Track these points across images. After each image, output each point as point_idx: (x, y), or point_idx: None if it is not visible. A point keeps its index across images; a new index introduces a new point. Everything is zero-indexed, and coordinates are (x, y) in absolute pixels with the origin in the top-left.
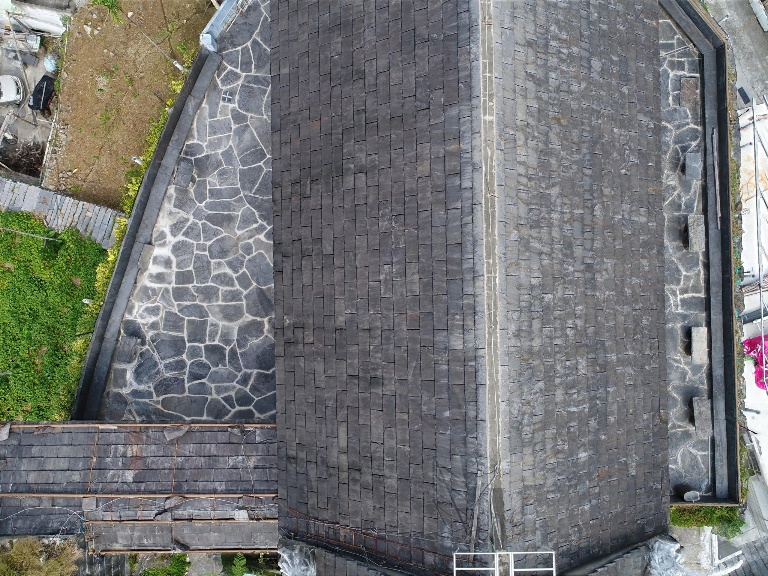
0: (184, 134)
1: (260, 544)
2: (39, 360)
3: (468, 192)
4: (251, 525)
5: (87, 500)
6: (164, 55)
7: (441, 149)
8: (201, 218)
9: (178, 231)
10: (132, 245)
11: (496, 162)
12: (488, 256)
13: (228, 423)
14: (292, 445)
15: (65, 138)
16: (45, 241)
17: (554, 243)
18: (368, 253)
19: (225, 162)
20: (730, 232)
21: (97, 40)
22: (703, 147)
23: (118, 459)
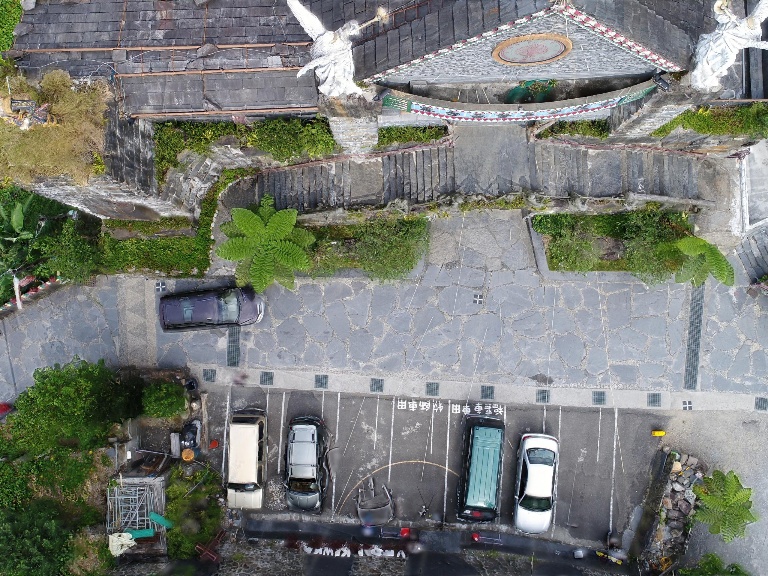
0: None
1: (293, 102)
2: None
3: None
4: (284, 77)
5: (117, 52)
6: None
7: None
8: None
9: None
10: None
11: None
12: None
13: None
14: None
15: None
16: None
17: None
18: None
19: None
20: None
21: None
22: None
23: (147, 22)
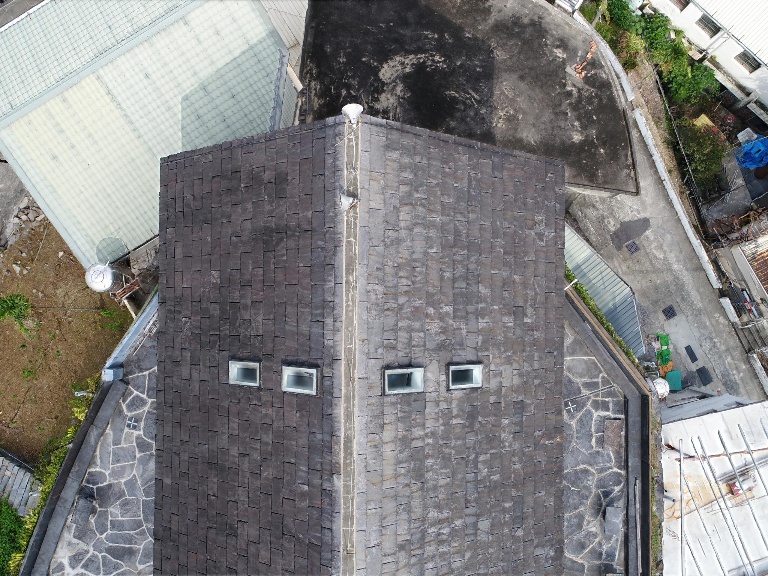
0: (85, 465)
1: None
2: None
3: None
4: None
5: None
6: (93, 300)
7: None
8: (101, 550)
9: (77, 563)
10: None
11: None
12: None
13: None
14: None
15: None
16: None
17: None
18: None
19: (128, 492)
20: None
21: (26, 279)
22: (626, 492)
23: None
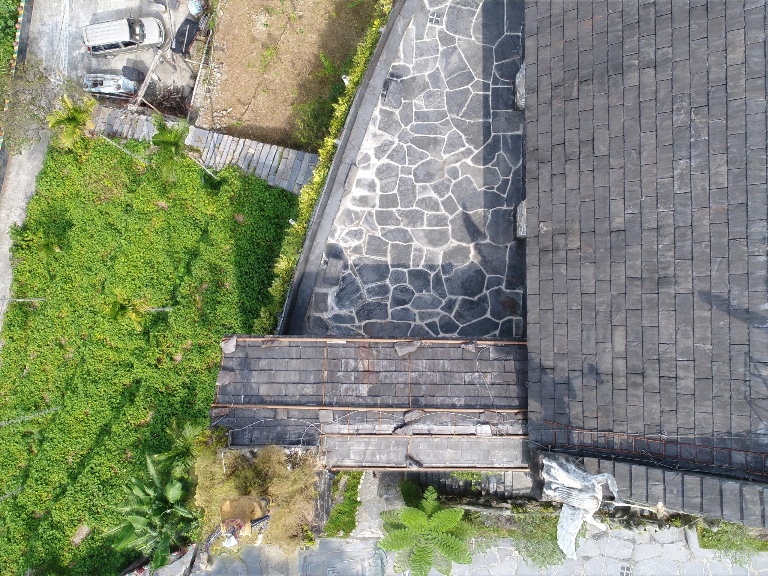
0: (393, 54)
1: (496, 462)
2: (199, 297)
3: None
4: (491, 442)
5: (324, 412)
6: None
7: (760, 34)
8: (406, 141)
9: (382, 154)
10: (338, 166)
11: None
12: None
13: (460, 340)
14: (548, 355)
15: (220, 77)
16: (203, 179)
17: None
18: (657, 149)
19: (432, 84)
20: None
21: None
22: None
23: (350, 373)
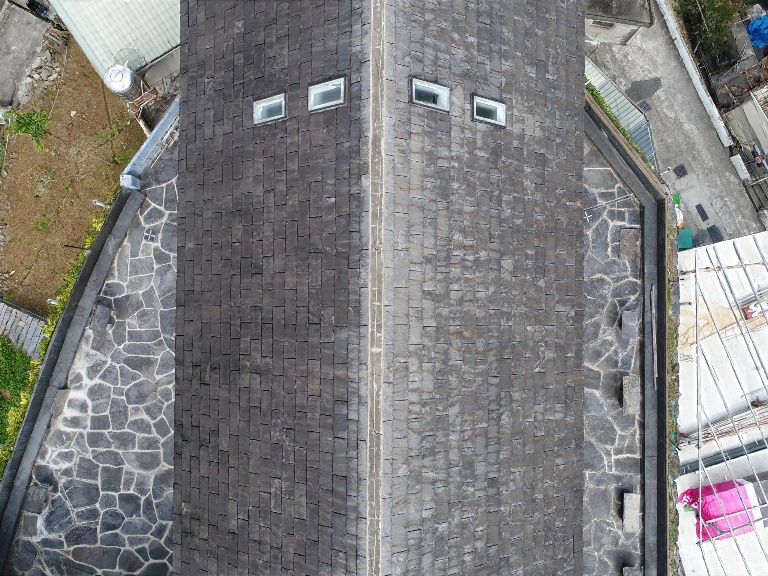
0: (103, 275)
1: None
2: None
3: (354, 425)
4: None
5: None
6: (106, 157)
7: (330, 371)
8: (119, 361)
9: (95, 374)
10: (45, 389)
11: (383, 397)
12: (371, 498)
13: None
14: None
15: (3, 239)
16: None
17: (451, 466)
18: (260, 461)
19: (146, 303)
20: (665, 397)
21: None
22: (642, 301)
23: None
